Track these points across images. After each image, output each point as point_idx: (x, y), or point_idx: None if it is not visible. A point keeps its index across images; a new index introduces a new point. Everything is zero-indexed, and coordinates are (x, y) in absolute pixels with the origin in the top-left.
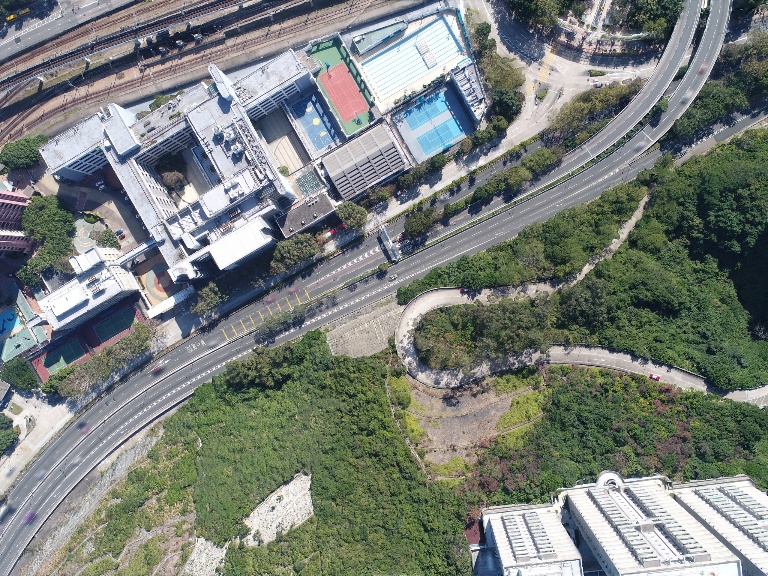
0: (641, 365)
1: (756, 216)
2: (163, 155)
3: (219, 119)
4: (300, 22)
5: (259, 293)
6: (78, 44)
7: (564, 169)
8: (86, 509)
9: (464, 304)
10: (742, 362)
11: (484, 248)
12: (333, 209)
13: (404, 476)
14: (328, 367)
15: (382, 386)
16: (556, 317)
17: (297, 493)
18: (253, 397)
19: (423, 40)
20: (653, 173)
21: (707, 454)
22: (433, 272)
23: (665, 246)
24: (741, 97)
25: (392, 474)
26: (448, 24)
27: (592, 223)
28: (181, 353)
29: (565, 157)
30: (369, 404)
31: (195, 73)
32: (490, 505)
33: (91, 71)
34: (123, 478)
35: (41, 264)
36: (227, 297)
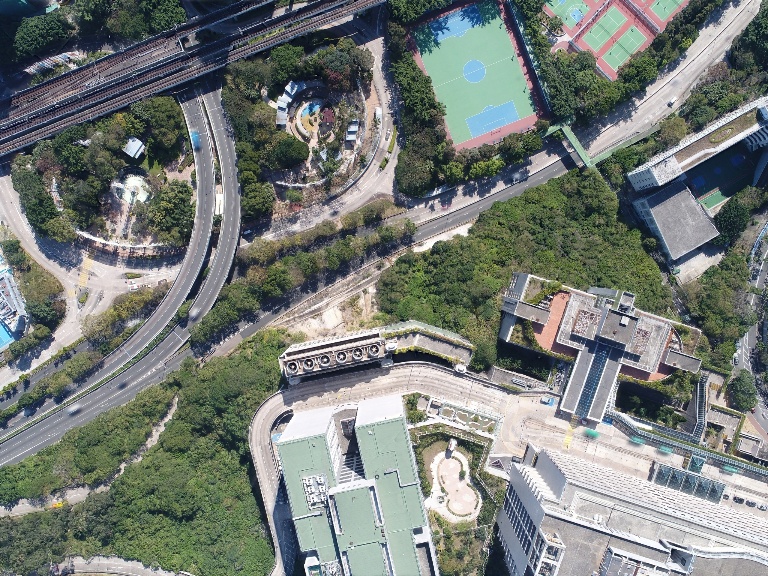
0: (153, 571)
1: (247, 425)
2: None
3: None
4: None
5: None
6: None
7: (107, 370)
8: None
9: None
10: (235, 566)
11: (39, 449)
12: None
13: None
14: None
15: None
16: None
17: None
18: None
19: None
20: (175, 377)
21: None
22: None
23: (194, 444)
24: (250, 301)
25: None
26: None
27: (127, 425)
28: None
29: (106, 359)
30: None
31: None
32: None
33: None
34: None
35: None
36: None
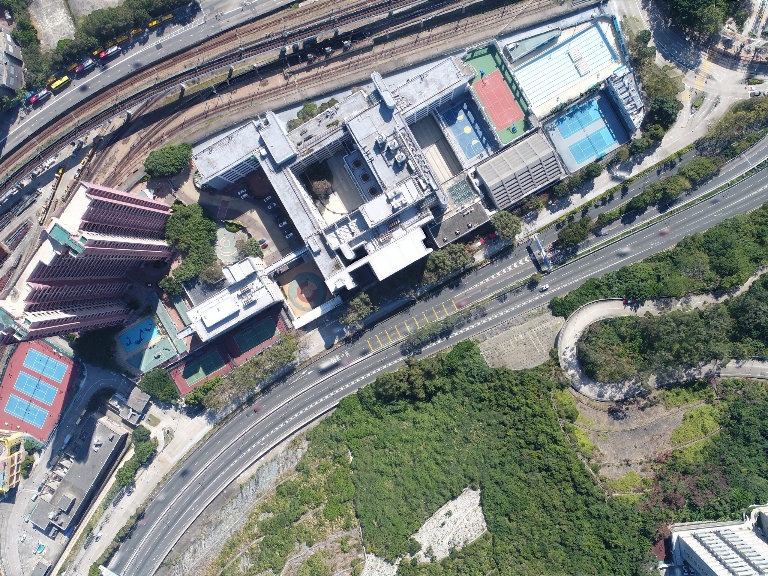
0: None
1: None
2: (312, 163)
3: (380, 128)
4: (450, 29)
5: (405, 303)
6: (222, 51)
7: (722, 178)
8: (231, 523)
9: (629, 316)
10: None
11: (639, 258)
12: (488, 219)
13: (579, 491)
14: (486, 379)
15: (548, 399)
16: (725, 329)
17: (467, 508)
18: (403, 409)
19: (576, 47)
20: None
21: None
22: (589, 283)
23: None
24: None
25: (566, 489)
26: (602, 31)
27: (755, 233)
28: (324, 364)
29: None
30: (535, 417)
31: (341, 80)
32: None
33: (235, 78)
34: (270, 491)
35: (186, 274)
36: (378, 308)
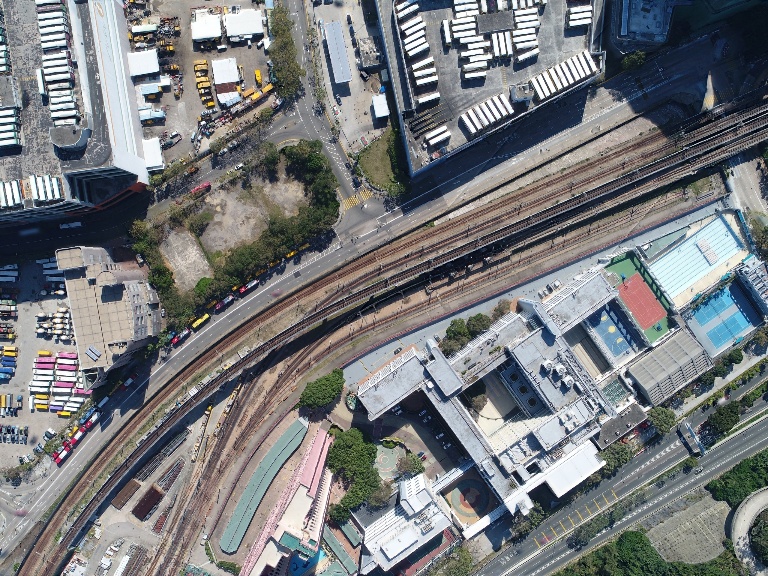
0: None
1: None
2: None
3: (544, 352)
4: (583, 233)
5: None
6: (362, 274)
7: None
8: None
9: None
10: None
11: None
12: (646, 417)
13: None
14: (665, 574)
15: None
16: None
17: None
18: None
19: (703, 239)
20: None
21: None
22: (745, 465)
23: None
24: None
25: None
26: (727, 222)
27: None
28: (495, 566)
29: None
30: None
31: (482, 291)
32: None
33: (377, 299)
34: None
35: (355, 501)
36: None
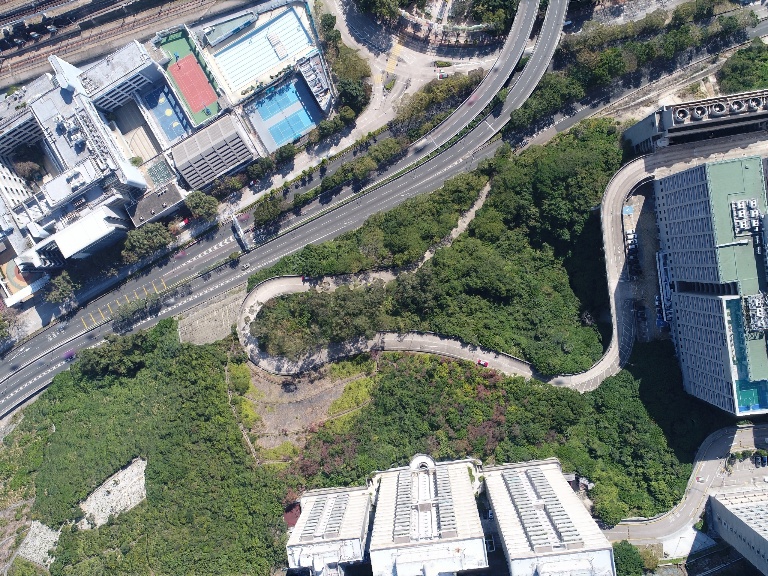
0: (470, 351)
1: (581, 204)
2: (18, 146)
3: (62, 109)
4: (153, 14)
5: (117, 282)
6: None
7: (410, 159)
8: None
9: (304, 292)
10: (564, 348)
11: (333, 237)
12: (182, 199)
13: (234, 460)
14: (174, 354)
15: (221, 372)
16: (392, 304)
17: (133, 477)
18: (107, 384)
19: (274, 31)
20: (491, 162)
21: (518, 437)
22: (281, 261)
23: (504, 235)
24: (577, 87)
25: (224, 458)
26: (298, 16)
27: (434, 212)
28: (41, 341)
29: (411, 147)
30: (208, 390)
31: None
32: (312, 488)
33: None
34: None
35: None
36: (80, 286)
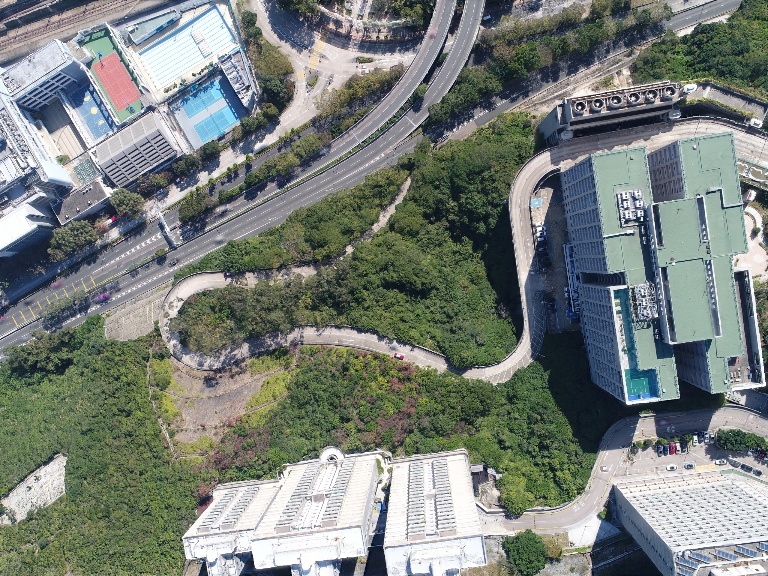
0: (387, 345)
1: (495, 198)
2: None
3: None
4: (78, 13)
5: (46, 280)
6: None
7: (333, 155)
8: None
9: (225, 287)
10: (477, 340)
11: (258, 233)
12: (106, 196)
13: (152, 455)
14: (99, 351)
15: (142, 368)
16: (311, 299)
17: (54, 473)
18: (36, 381)
19: (198, 29)
20: (410, 157)
21: (427, 429)
22: (206, 257)
23: (424, 229)
24: (493, 81)
25: (143, 453)
26: (221, 13)
27: (355, 207)
28: None
29: (334, 143)
30: (129, 386)
31: None
32: (226, 482)
33: None
34: None
35: None
36: (7, 284)
